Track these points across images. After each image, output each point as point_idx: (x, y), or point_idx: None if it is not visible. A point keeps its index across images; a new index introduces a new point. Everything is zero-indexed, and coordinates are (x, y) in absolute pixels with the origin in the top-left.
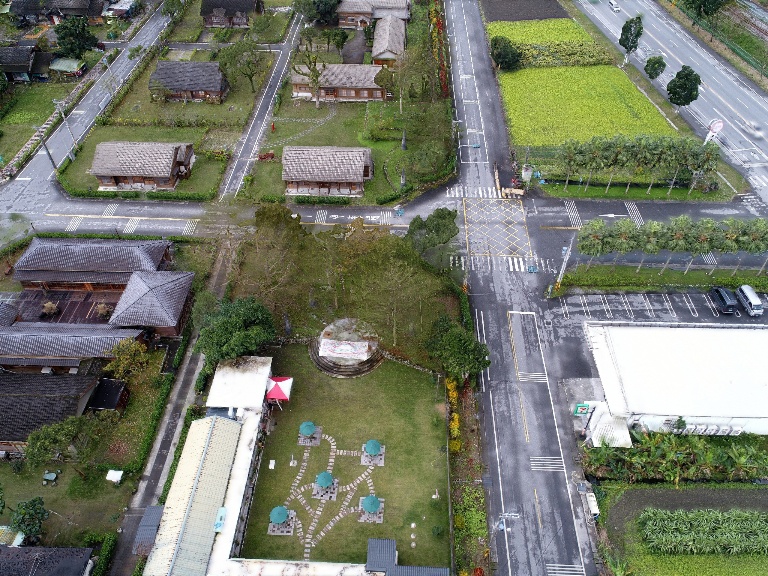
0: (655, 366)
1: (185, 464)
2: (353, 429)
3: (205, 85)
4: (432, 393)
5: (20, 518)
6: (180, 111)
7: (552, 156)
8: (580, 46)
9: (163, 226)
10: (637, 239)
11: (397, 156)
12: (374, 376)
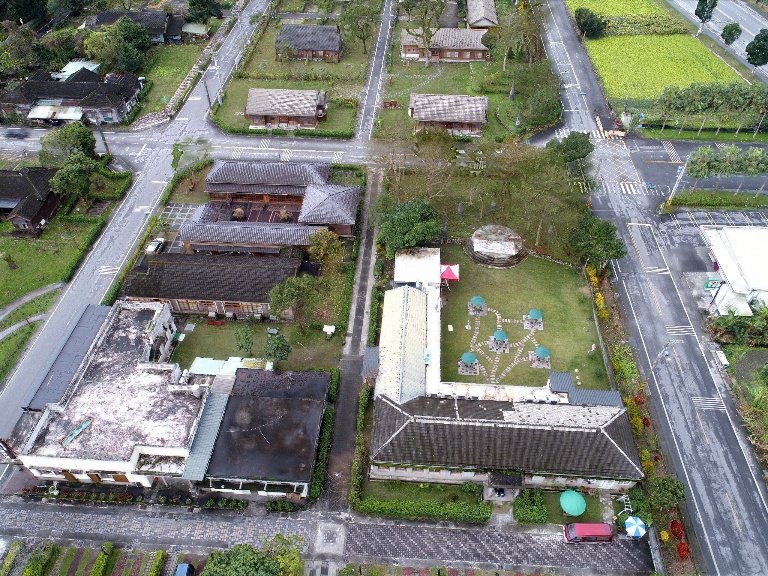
0: (767, 256)
1: (389, 319)
2: (513, 304)
3: (325, 45)
4: (574, 280)
5: (275, 346)
6: (304, 68)
7: (645, 107)
8: (656, 18)
9: (314, 156)
10: (739, 163)
11: (506, 105)
12: (522, 267)
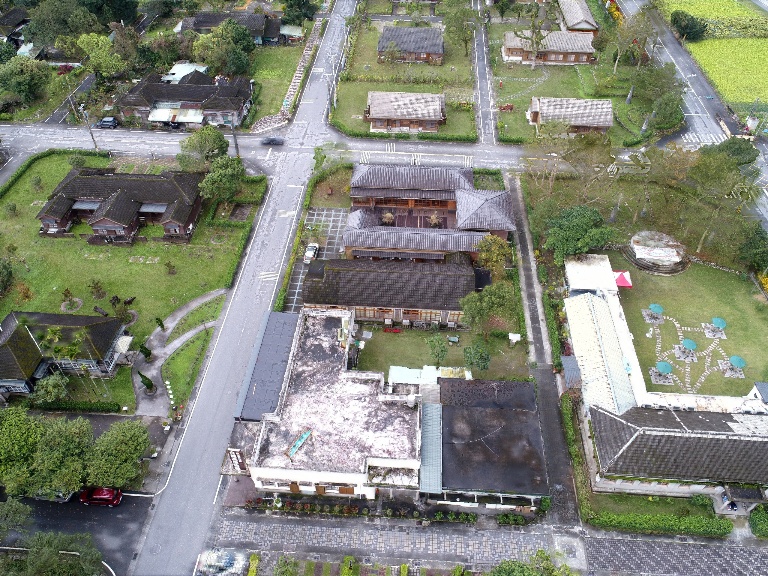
0: None
1: (578, 327)
2: (688, 312)
3: (429, 48)
4: (745, 287)
5: (479, 355)
6: (408, 70)
7: (765, 111)
8: (751, 21)
9: (444, 160)
10: None
11: (624, 109)
12: (688, 274)
